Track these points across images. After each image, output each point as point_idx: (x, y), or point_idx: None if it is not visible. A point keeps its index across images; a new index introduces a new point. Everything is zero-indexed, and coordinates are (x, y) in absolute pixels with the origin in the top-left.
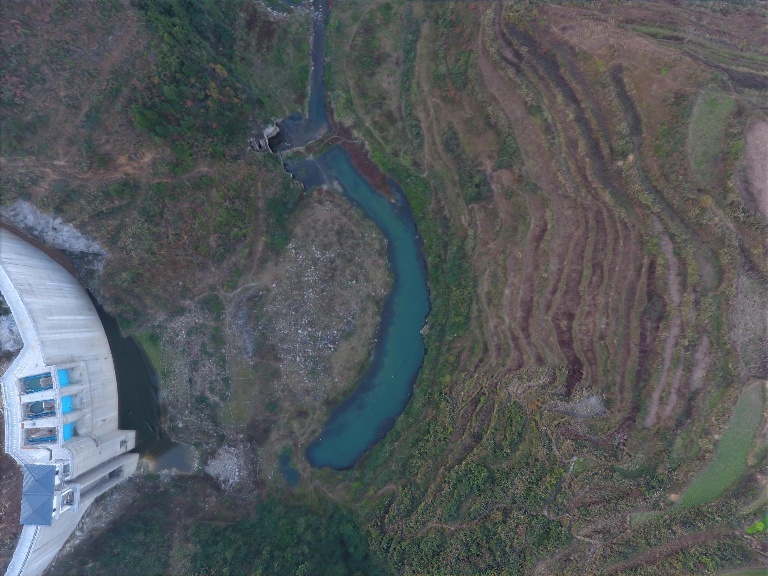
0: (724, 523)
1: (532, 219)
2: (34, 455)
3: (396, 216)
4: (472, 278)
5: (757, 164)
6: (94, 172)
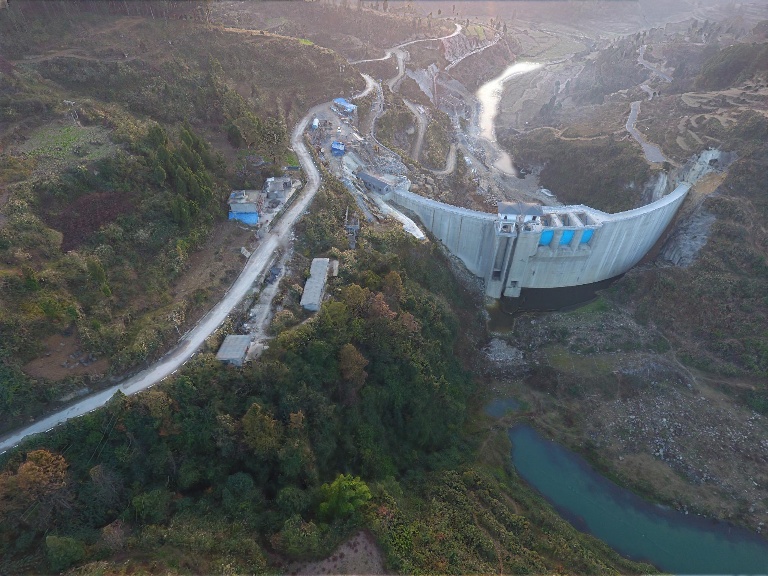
0: None
1: None
2: None
3: None
4: None
5: None
6: (766, 250)
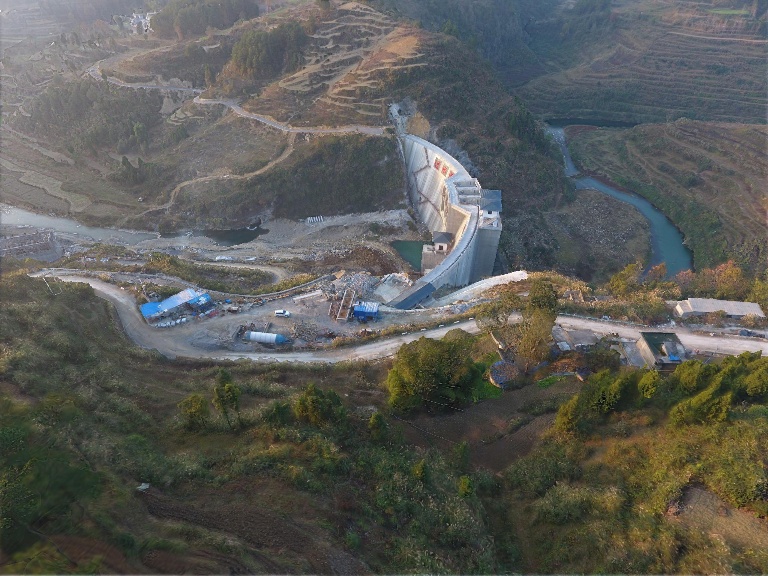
0: None
1: (738, 184)
2: (467, 207)
3: (637, 201)
4: None
5: None
6: (486, 136)
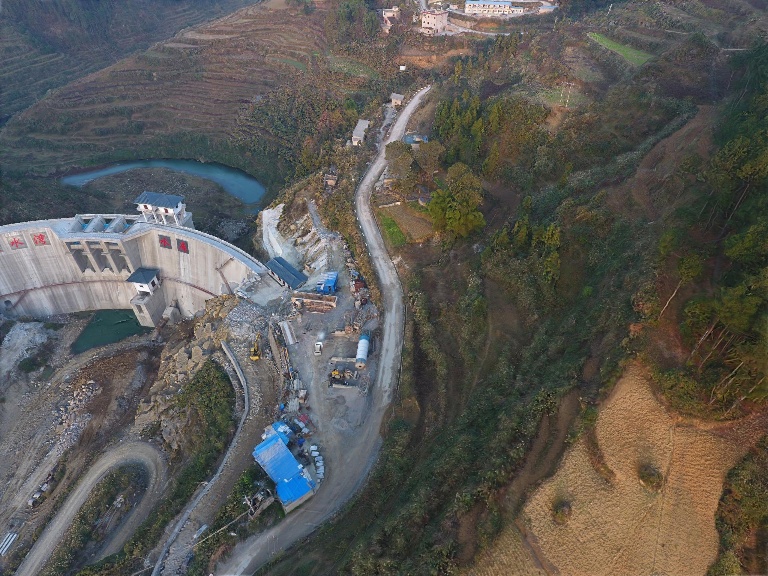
0: (311, 58)
1: None
2: (135, 229)
3: (128, 165)
4: None
5: (179, 46)
6: None
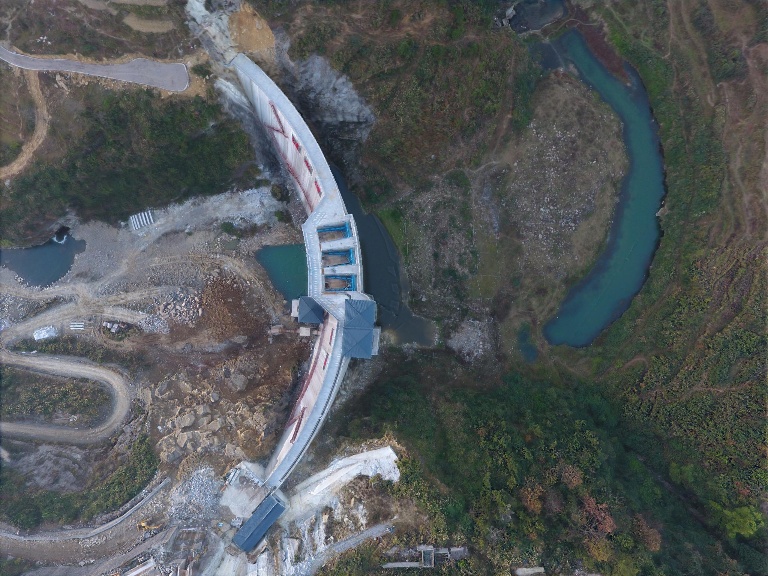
0: None
1: None
2: (334, 300)
3: (631, 100)
4: (725, 154)
5: None
6: (383, 29)
